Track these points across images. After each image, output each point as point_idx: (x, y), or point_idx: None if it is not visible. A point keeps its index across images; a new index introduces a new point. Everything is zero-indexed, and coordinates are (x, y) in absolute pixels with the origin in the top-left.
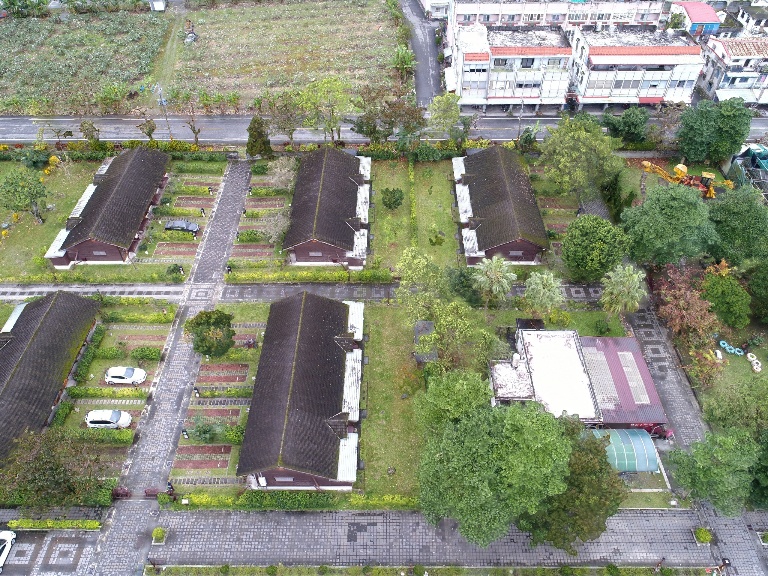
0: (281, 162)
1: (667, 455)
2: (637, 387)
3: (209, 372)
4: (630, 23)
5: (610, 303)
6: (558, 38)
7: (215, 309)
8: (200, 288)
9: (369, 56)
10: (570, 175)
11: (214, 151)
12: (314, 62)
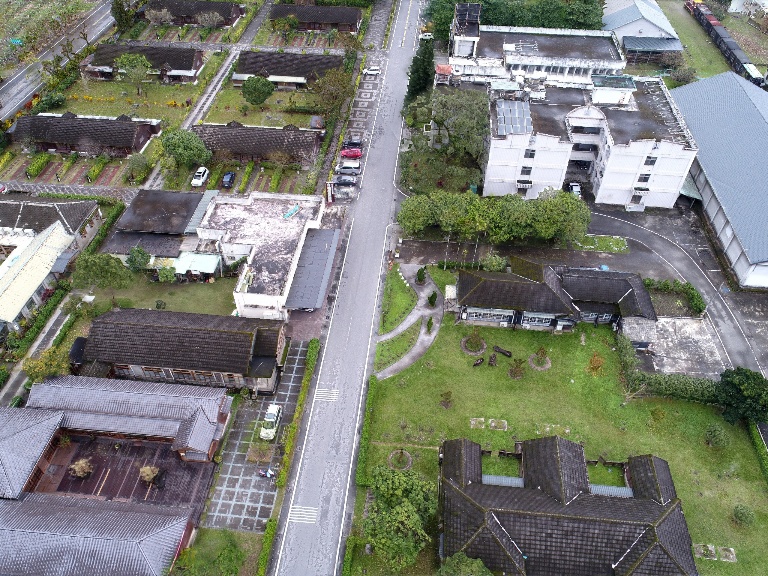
0: (153, 11)
1: None
2: None
3: (296, 44)
4: None
5: None
6: None
7: (254, 45)
8: None
9: (6, 3)
10: None
11: (104, 43)
12: None
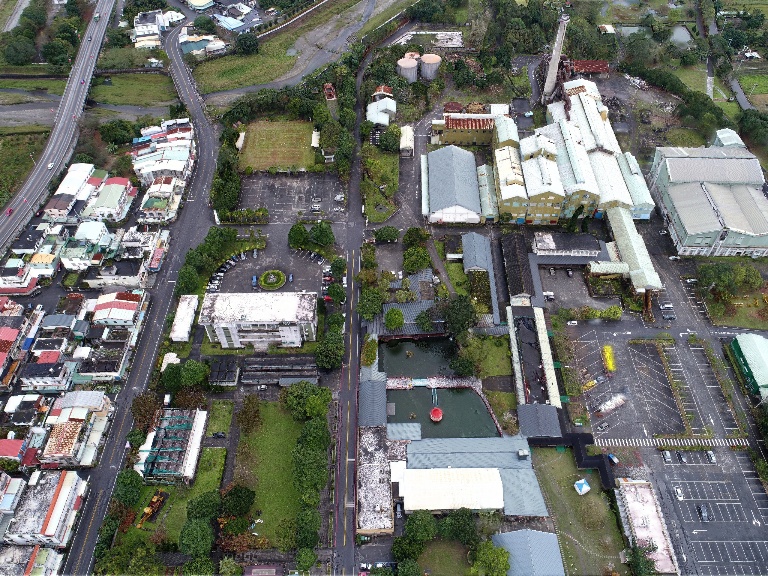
0: None
1: (291, 567)
2: (268, 572)
3: None
4: (2, 494)
5: (230, 572)
6: (14, 550)
7: None
8: None
9: None
10: (154, 573)
11: None
12: None
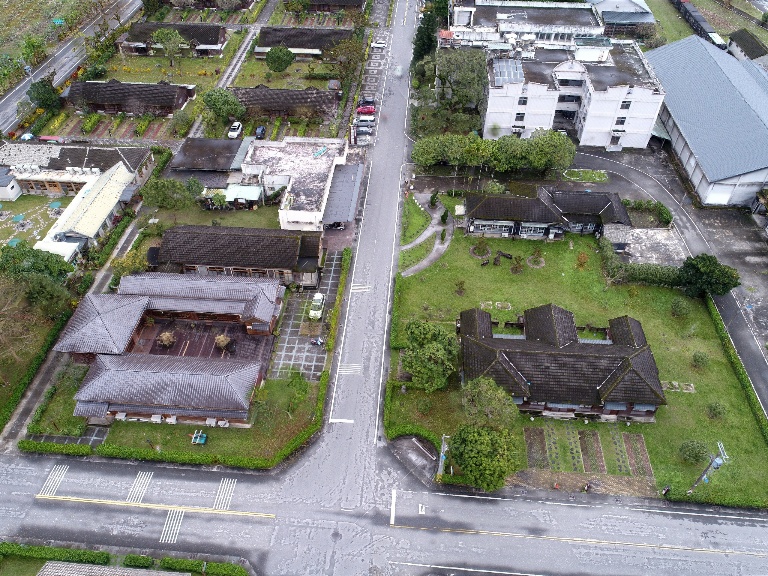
0: None
1: None
2: None
3: None
4: None
5: None
6: None
7: (270, 24)
8: (254, 28)
9: None
10: None
11: None
12: (27, 6)
